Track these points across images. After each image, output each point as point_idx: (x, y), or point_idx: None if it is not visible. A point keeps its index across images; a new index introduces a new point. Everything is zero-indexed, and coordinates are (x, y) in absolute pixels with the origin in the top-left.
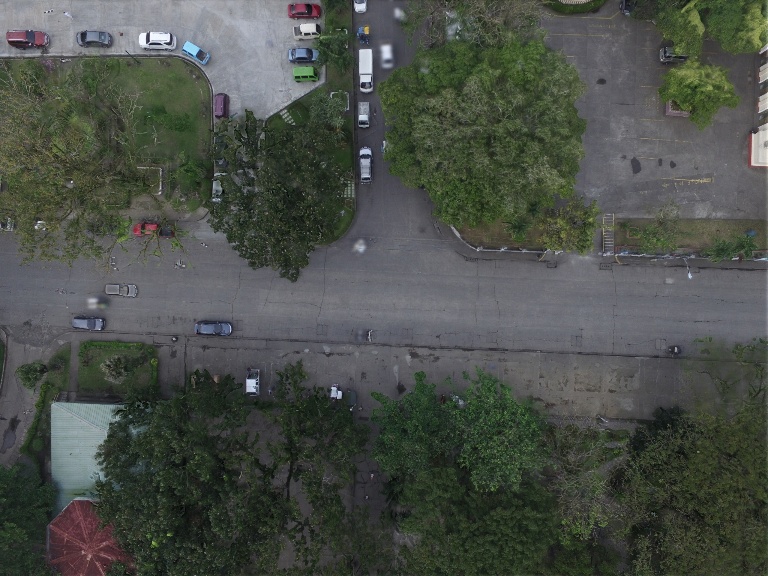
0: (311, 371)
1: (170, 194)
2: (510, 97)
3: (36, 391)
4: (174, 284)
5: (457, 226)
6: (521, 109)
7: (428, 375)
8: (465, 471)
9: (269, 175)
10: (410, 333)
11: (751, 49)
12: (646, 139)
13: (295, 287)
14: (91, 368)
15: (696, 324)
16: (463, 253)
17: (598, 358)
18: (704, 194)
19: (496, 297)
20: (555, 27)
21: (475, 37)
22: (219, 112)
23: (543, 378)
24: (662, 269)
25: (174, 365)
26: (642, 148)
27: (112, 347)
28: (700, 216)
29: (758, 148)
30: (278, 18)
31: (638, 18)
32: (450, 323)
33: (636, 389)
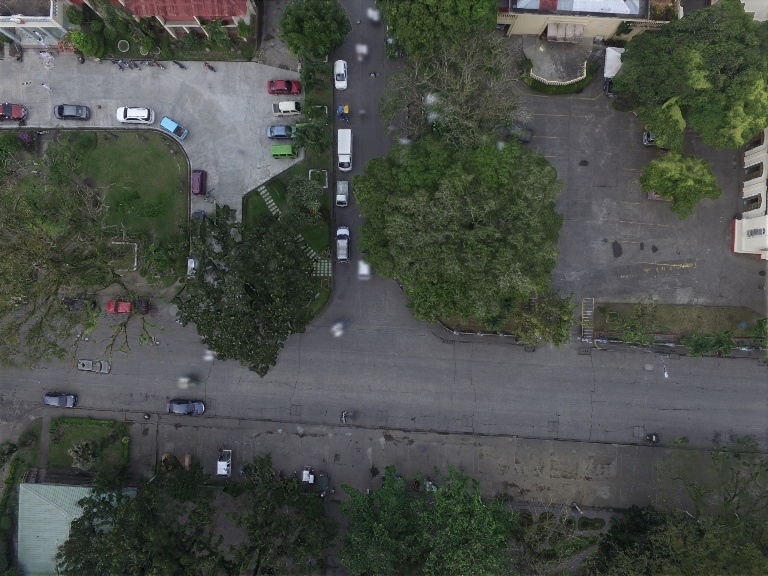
0: (284, 452)
1: (145, 270)
2: (483, 202)
3: (5, 469)
4: (147, 361)
5: None
6: (495, 212)
7: (402, 458)
8: None
9: (236, 278)
10: (385, 415)
11: (732, 146)
12: (628, 222)
13: (269, 366)
14: (62, 445)
15: (675, 412)
16: (440, 335)
17: (575, 444)
18: (686, 280)
19: (473, 380)
20: (538, 107)
21: (449, 137)
22: (195, 190)
23: (519, 464)
24: (642, 355)
25: (146, 443)
26: (624, 232)
27: (83, 424)
28: (681, 302)
29: (741, 236)
30: (258, 93)
31: (619, 110)
32: (425, 406)
33: (613, 477)
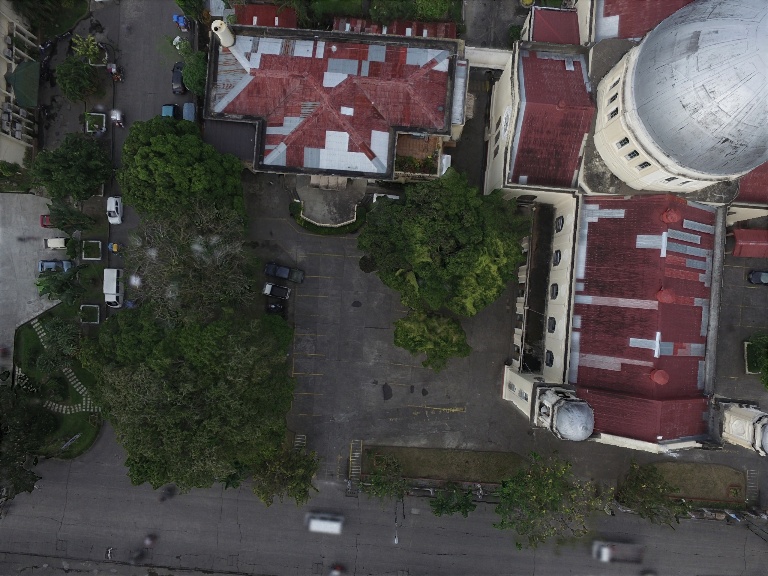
0: None
1: None
2: (181, 385)
3: None
4: None
5: None
6: (200, 391)
7: None
8: None
9: None
10: (150, 553)
11: (466, 315)
12: (399, 365)
13: (37, 501)
14: None
15: (440, 557)
16: None
17: None
18: (455, 424)
19: (238, 520)
20: (313, 246)
21: None
22: None
23: None
24: (408, 499)
25: None
26: (394, 374)
27: None
28: (450, 446)
29: (506, 384)
30: (34, 225)
31: (362, 270)
32: (191, 544)
33: None
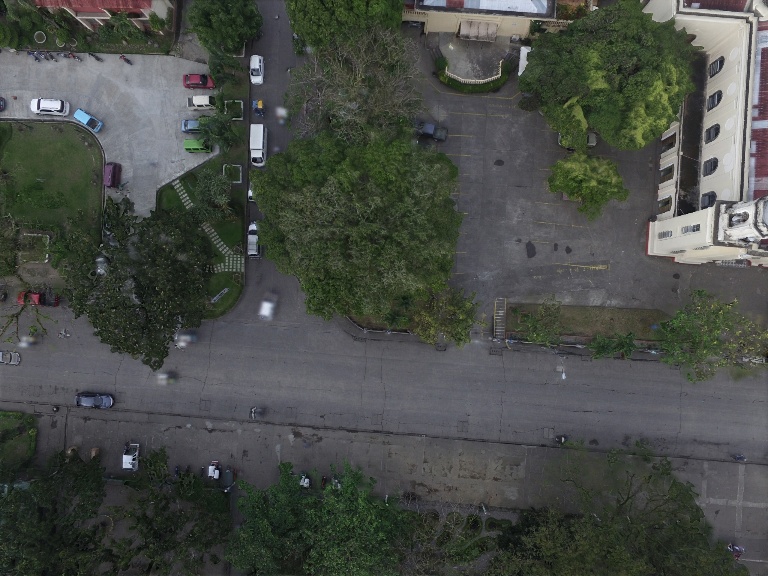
0: (192, 447)
1: (57, 262)
2: (369, 199)
3: None
4: (57, 353)
5: (324, 319)
6: (383, 209)
7: (310, 455)
8: None
9: (118, 271)
10: (294, 412)
11: (634, 148)
12: (542, 223)
13: (180, 361)
14: None
15: (585, 414)
16: (351, 332)
17: (484, 445)
18: (599, 281)
19: (383, 379)
20: (454, 105)
21: (341, 133)
22: (107, 182)
23: (427, 463)
24: (553, 356)
25: (54, 435)
26: (538, 232)
27: None
28: (594, 303)
29: (653, 238)
30: (174, 87)
31: (524, 109)
32: (335, 403)
33: (521, 478)
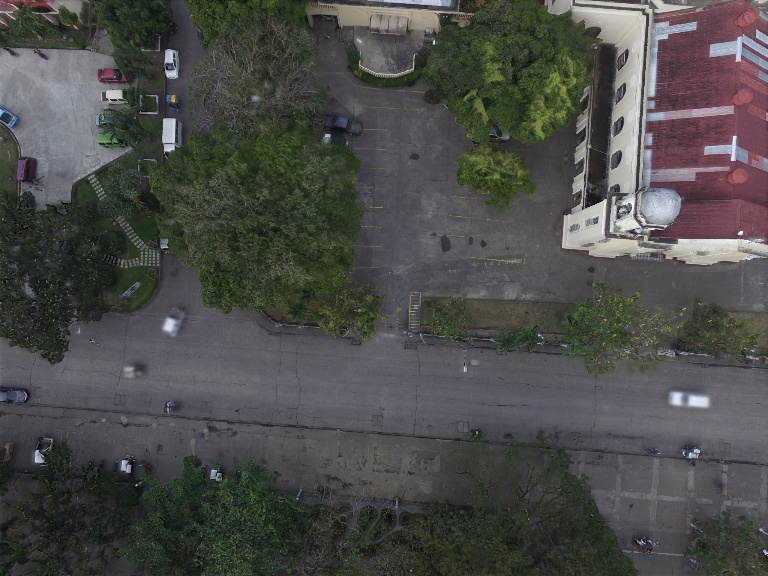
0: (107, 441)
1: None
2: (257, 191)
3: None
4: None
5: None
6: (274, 201)
7: (225, 450)
8: (199, 571)
9: (5, 264)
10: (209, 406)
11: (534, 140)
12: (457, 217)
13: (95, 355)
14: None
15: (500, 408)
16: (266, 327)
17: (398, 439)
18: (514, 275)
19: (297, 373)
20: (370, 99)
21: (232, 126)
22: (20, 177)
23: (342, 457)
24: (468, 350)
25: None
26: (453, 226)
27: None
28: (509, 297)
29: (566, 232)
30: (90, 81)
31: (427, 102)
32: (250, 398)
33: (436, 472)
